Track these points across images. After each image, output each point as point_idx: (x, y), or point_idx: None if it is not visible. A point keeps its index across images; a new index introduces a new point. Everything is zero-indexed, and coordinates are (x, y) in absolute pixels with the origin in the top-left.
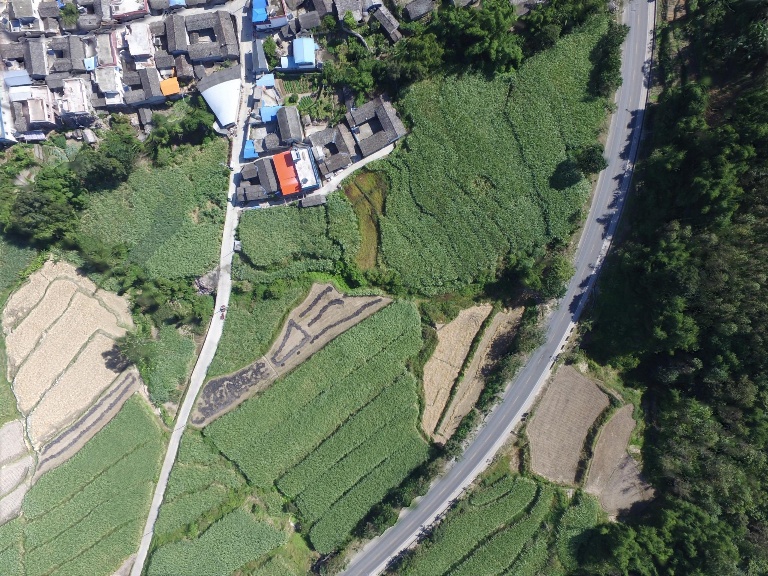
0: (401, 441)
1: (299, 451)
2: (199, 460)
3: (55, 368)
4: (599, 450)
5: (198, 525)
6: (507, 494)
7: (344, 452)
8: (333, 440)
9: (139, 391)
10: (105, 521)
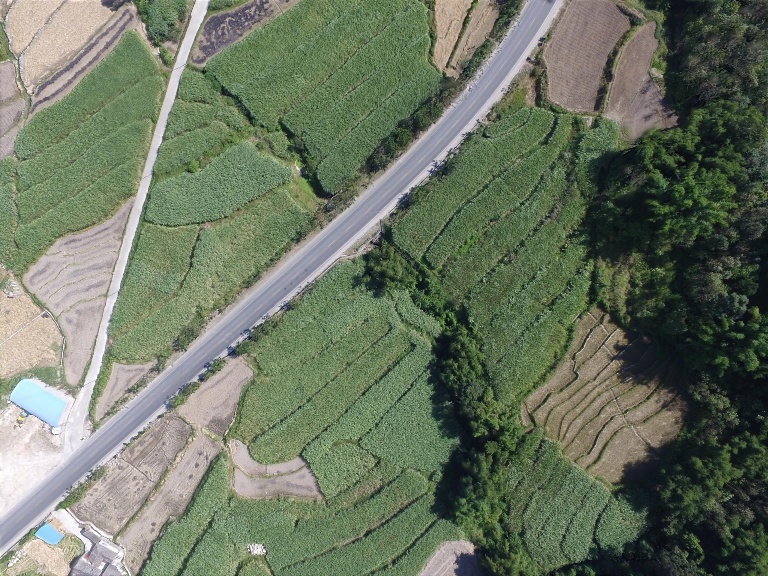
0: (412, 71)
1: (305, 86)
2: (200, 98)
3: (48, 6)
4: (620, 72)
5: (199, 162)
6: (523, 125)
7: (352, 84)
8: (341, 71)
9: (137, 29)
10: (102, 159)
